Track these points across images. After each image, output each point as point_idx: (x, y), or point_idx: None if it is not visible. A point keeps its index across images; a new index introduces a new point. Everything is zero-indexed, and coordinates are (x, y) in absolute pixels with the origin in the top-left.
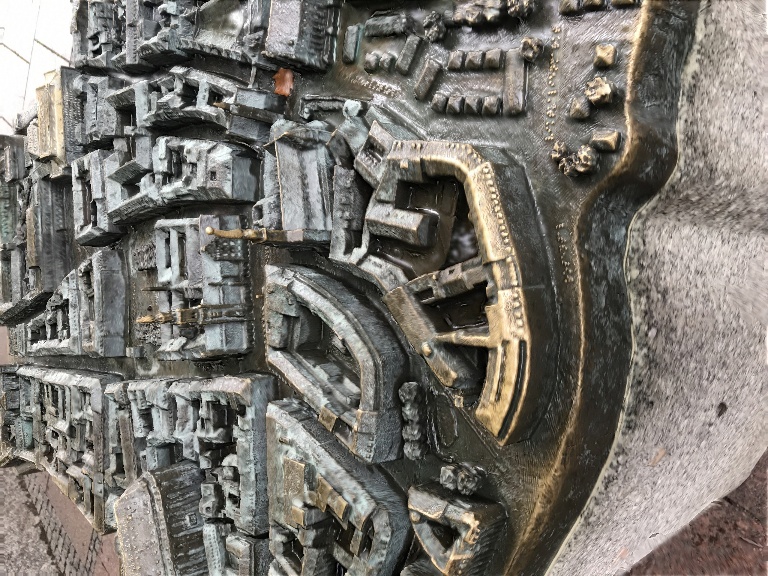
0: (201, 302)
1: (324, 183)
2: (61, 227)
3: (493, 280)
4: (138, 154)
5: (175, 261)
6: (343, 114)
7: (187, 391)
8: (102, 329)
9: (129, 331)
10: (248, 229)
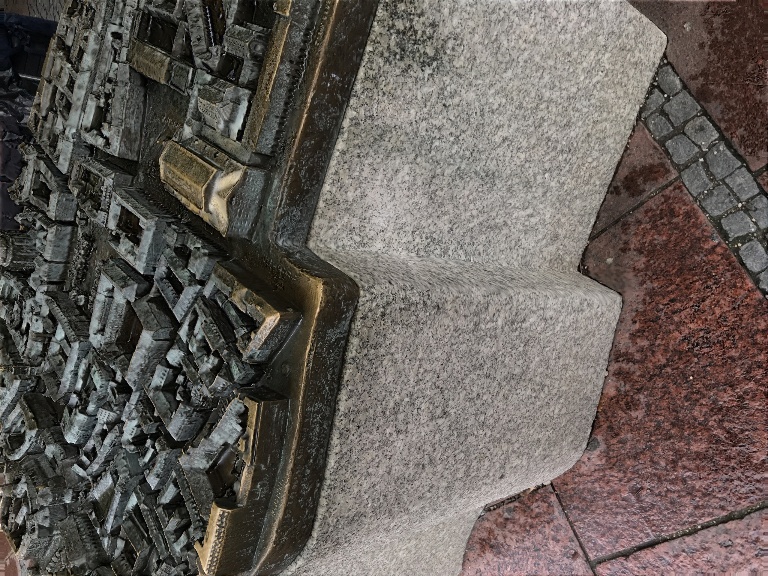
0: (43, 363)
1: None
2: None
3: (5, 530)
4: None
5: None
6: None
7: None
8: None
9: None
10: None
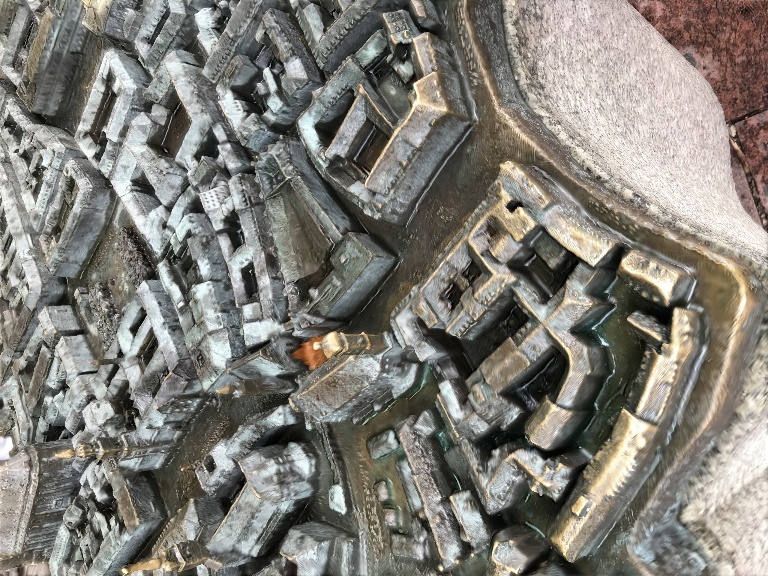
0: (136, 421)
1: (273, 523)
2: (78, 49)
3: None
4: (162, 187)
5: (138, 343)
6: (329, 491)
7: (97, 432)
8: (61, 255)
9: (89, 263)
10: (168, 562)
